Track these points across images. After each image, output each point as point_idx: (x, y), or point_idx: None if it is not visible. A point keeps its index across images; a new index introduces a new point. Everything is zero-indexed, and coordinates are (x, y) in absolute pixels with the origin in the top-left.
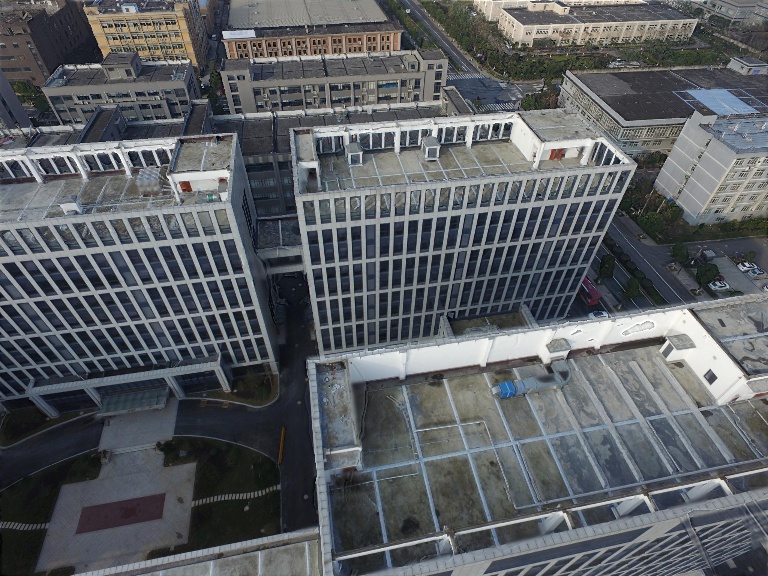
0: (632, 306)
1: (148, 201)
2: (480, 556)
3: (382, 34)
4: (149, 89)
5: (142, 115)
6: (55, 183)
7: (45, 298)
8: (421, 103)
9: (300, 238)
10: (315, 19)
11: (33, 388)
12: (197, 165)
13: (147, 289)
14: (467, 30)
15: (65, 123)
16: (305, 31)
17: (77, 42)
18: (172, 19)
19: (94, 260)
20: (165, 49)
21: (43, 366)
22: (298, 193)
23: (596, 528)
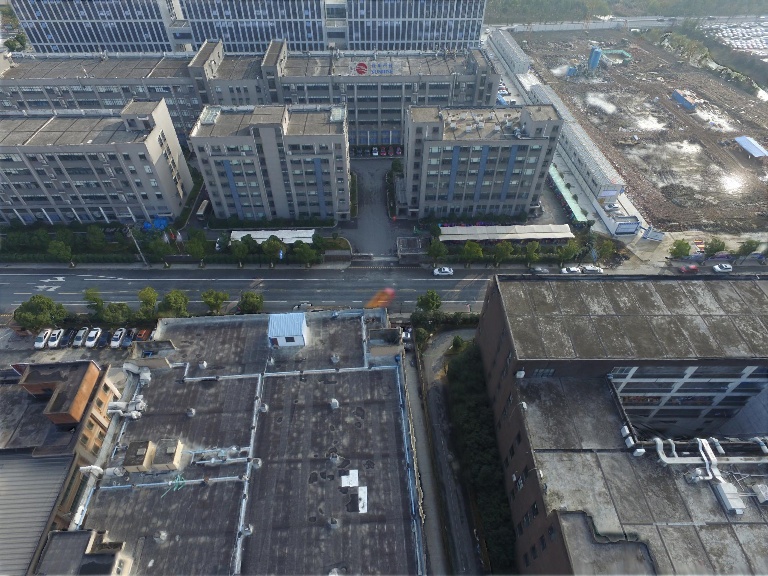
0: None
1: None
2: None
3: None
4: None
5: None
6: None
7: None
8: (6, 80)
9: (176, 23)
10: None
11: None
12: None
13: None
14: None
15: None
16: None
17: None
18: None
19: None
20: None
21: None
22: None
23: None
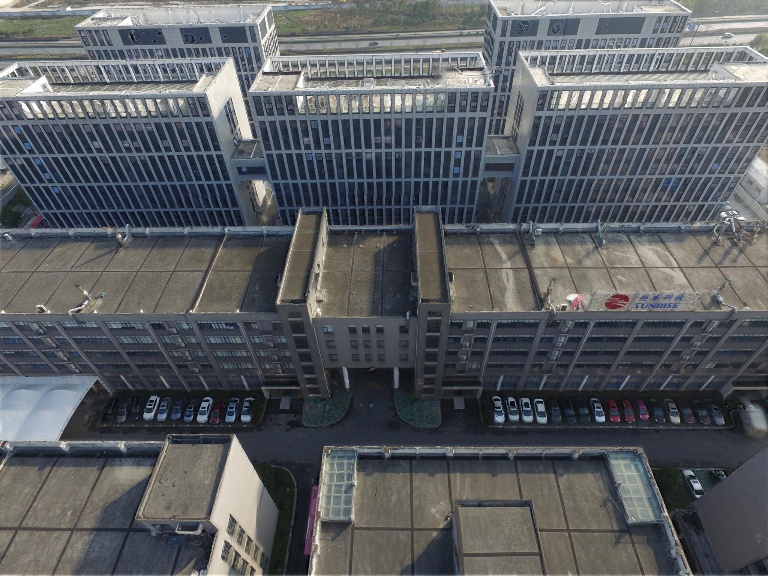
0: (26, 215)
1: None
2: (236, 8)
3: None
4: None
5: None
6: None
7: None
8: None
9: (241, 146)
10: None
11: None
12: (284, 78)
13: None
14: None
15: None
16: None
17: None
18: None
19: None
20: None
21: None
22: (229, 58)
23: (206, 12)
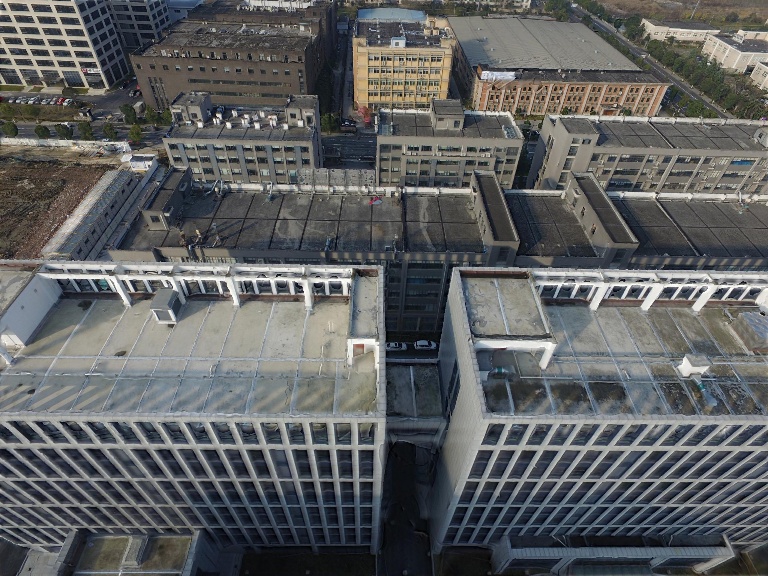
0: None
1: (765, 363)
2: None
3: (648, 86)
4: (483, 145)
5: (464, 171)
6: (608, 312)
7: (639, 480)
8: None
9: None
10: (562, 62)
11: (513, 550)
12: None
13: (758, 482)
14: (723, 84)
15: (381, 171)
16: (559, 75)
17: (320, 68)
18: (439, 56)
19: (753, 456)
20: (420, 85)
21: (533, 526)
22: None
23: None
